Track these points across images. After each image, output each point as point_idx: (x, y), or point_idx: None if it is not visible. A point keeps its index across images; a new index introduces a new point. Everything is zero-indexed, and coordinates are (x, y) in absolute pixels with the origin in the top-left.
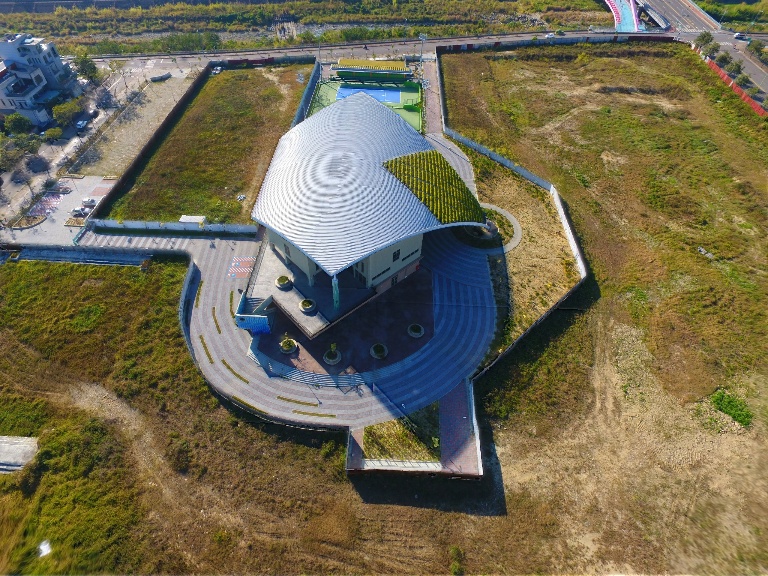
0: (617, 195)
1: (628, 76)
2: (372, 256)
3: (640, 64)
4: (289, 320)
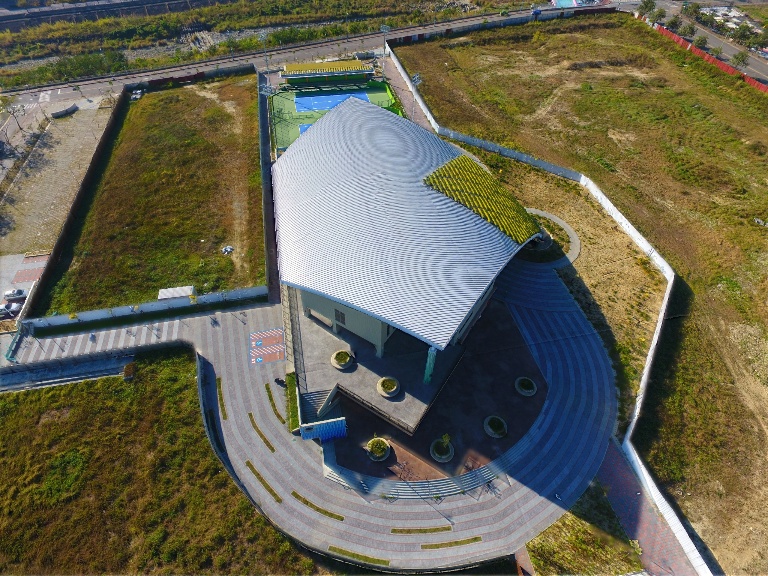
0: (647, 175)
1: (590, 50)
2: None
3: (595, 37)
4: (362, 410)
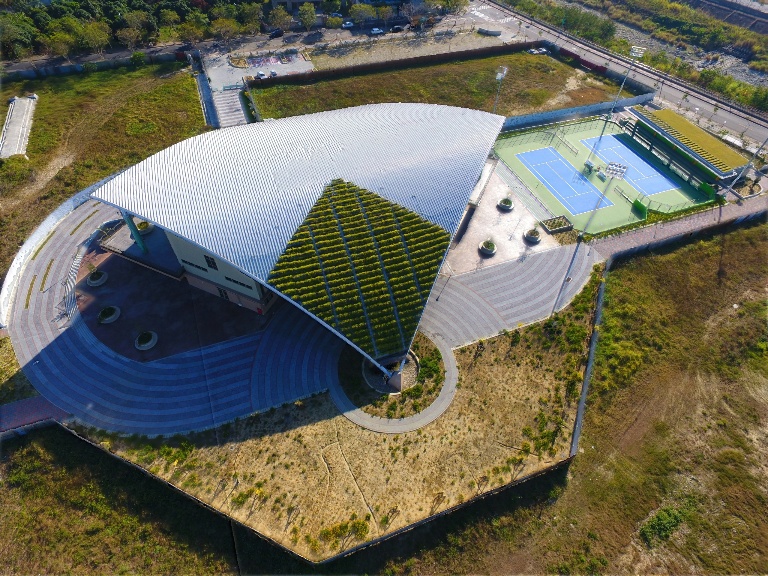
0: None
1: None
2: None
3: None
4: None
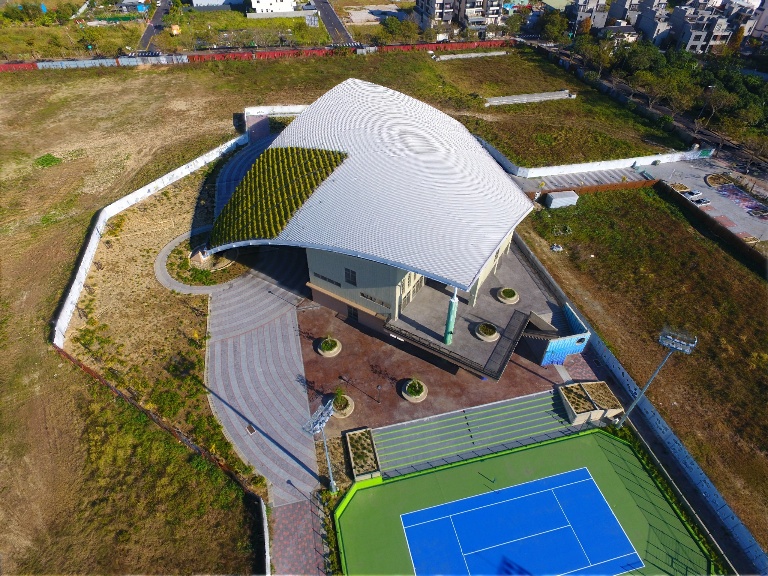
0: None
1: None
2: None
3: None
4: None
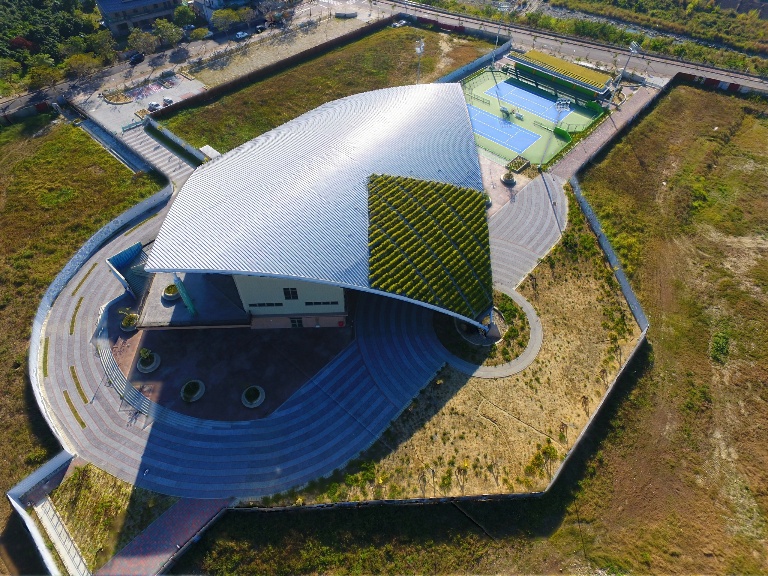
0: (762, 404)
1: None
2: (239, 277)
3: None
4: None
